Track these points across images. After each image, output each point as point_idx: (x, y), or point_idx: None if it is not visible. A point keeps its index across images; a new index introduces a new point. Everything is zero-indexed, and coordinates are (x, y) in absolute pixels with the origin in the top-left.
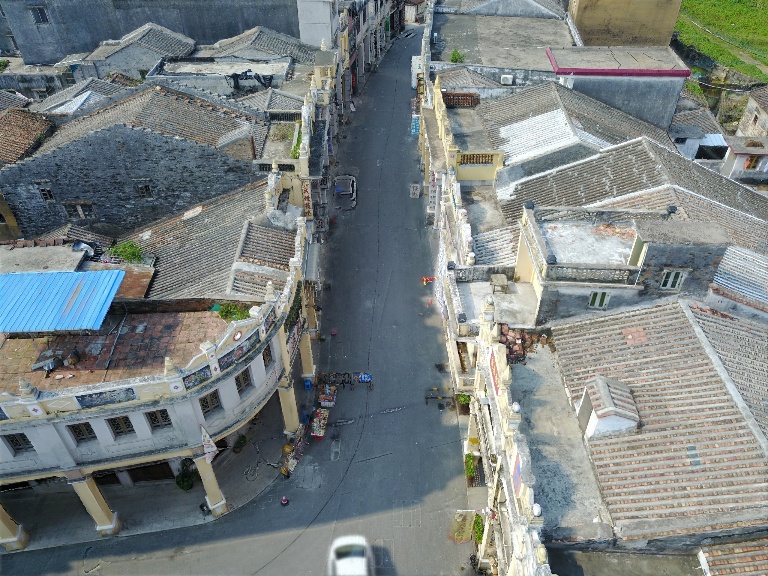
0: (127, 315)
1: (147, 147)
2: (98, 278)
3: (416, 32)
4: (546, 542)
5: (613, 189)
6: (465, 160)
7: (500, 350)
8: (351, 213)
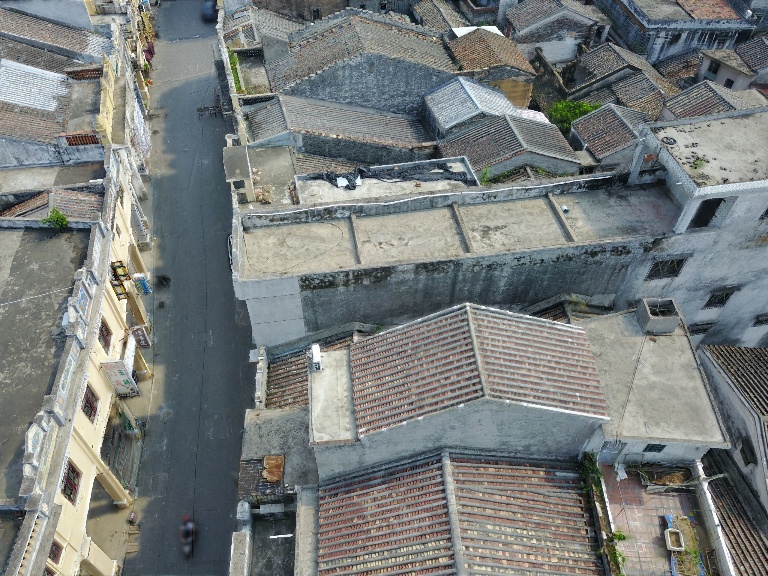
0: None
1: None
2: None
3: None
4: None
5: (3, 47)
6: (99, 74)
7: None
8: None
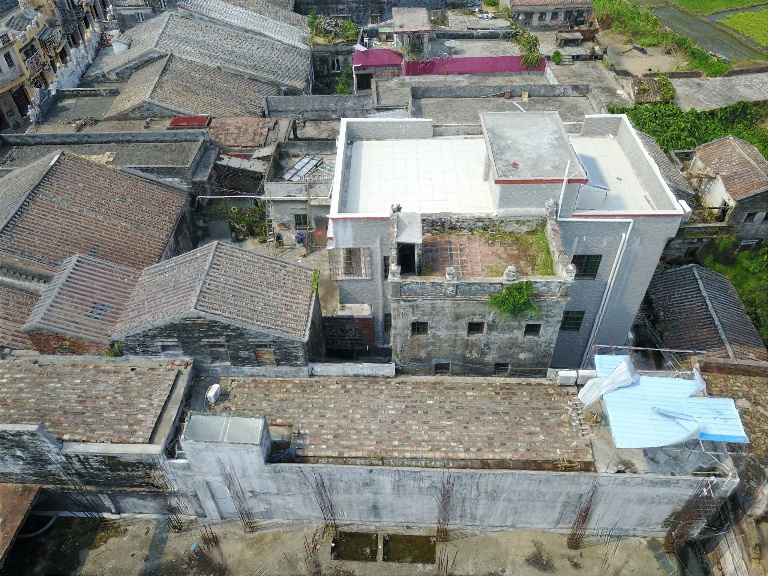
0: None
1: None
2: None
3: None
4: (83, 79)
5: None
6: None
7: None
8: None
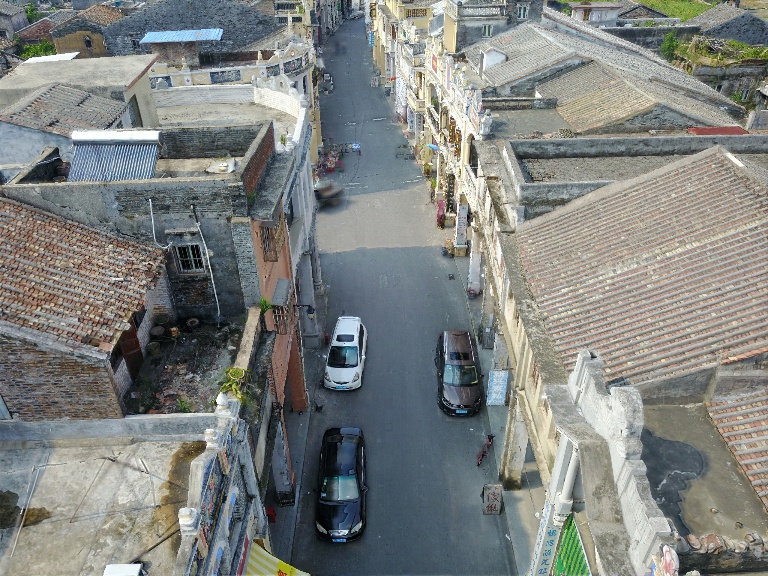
0: (221, 61)
1: (207, 6)
2: (209, 30)
3: (361, 15)
4: None
5: None
6: (409, 14)
7: (436, 43)
8: (330, 95)
